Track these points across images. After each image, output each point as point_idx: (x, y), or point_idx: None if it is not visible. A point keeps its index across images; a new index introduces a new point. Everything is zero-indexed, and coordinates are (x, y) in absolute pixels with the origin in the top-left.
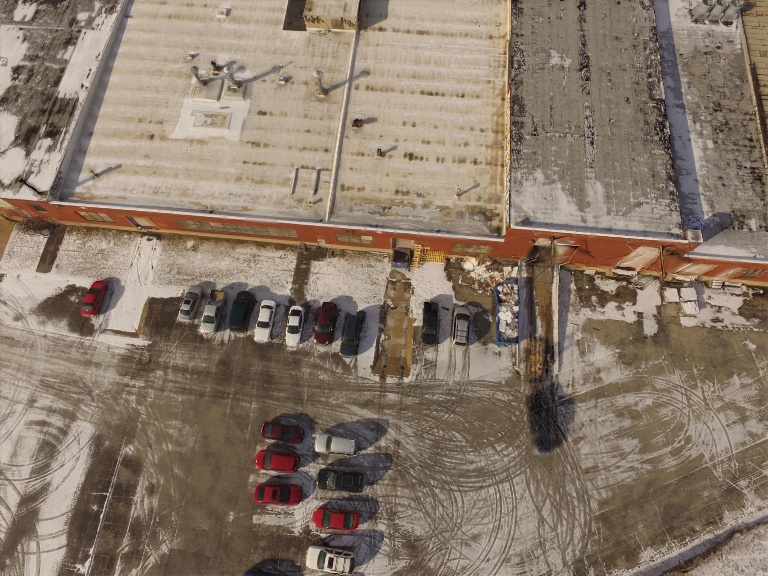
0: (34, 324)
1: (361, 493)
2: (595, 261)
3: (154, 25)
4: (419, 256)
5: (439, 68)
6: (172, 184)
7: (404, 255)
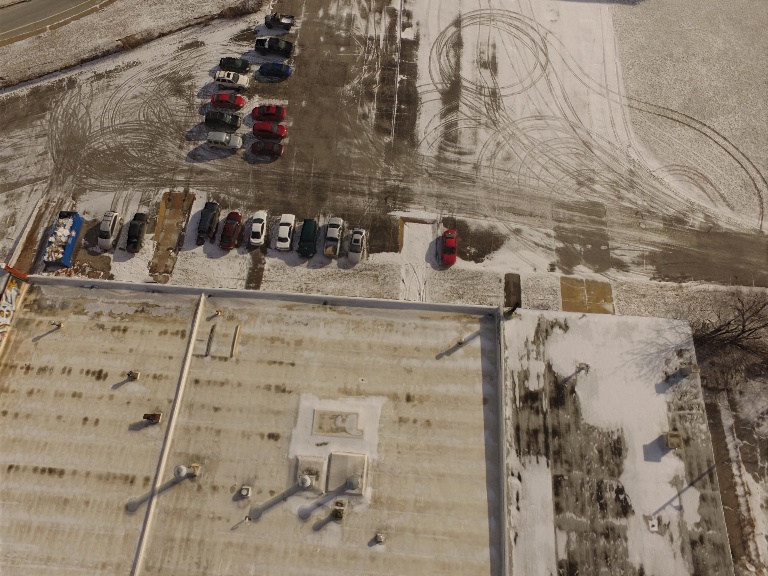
0: (500, 226)
1: None
2: None
3: None
4: None
5: (27, 519)
6: (373, 336)
7: None
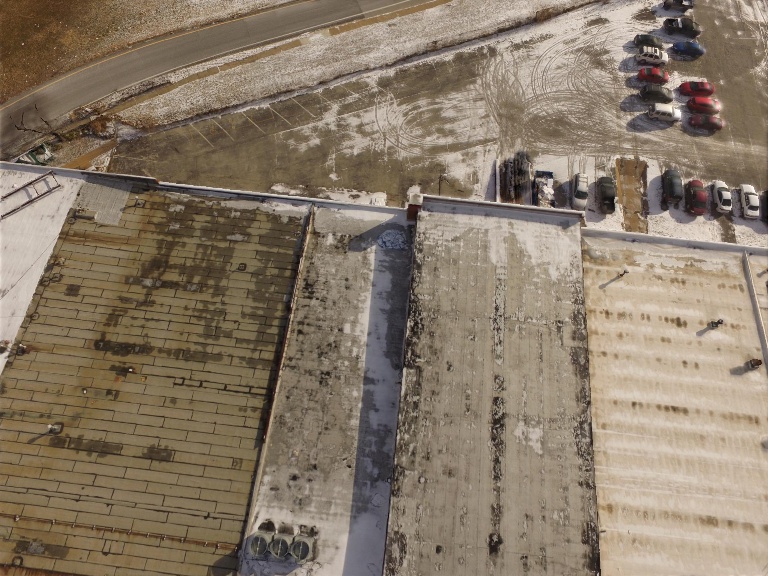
0: None
1: None
2: None
3: None
4: None
5: (673, 452)
6: None
7: None
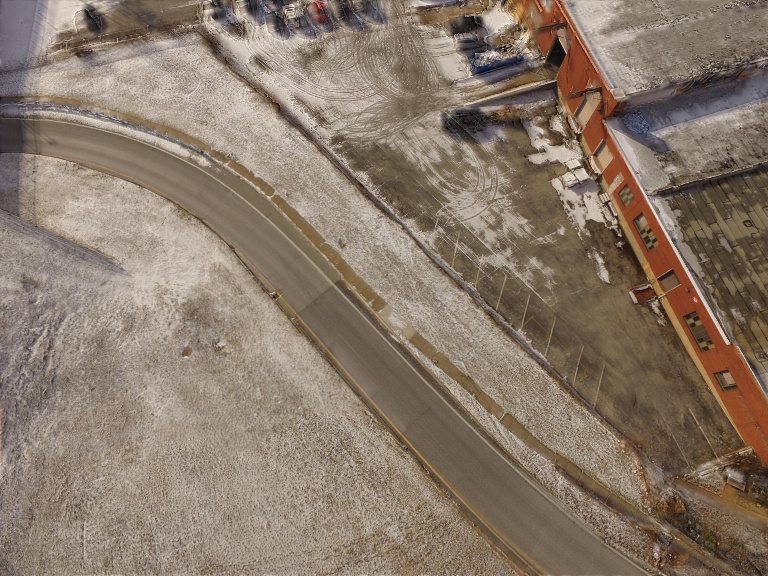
0: None
1: (333, 22)
2: (567, 93)
3: None
4: None
5: None
6: None
7: None
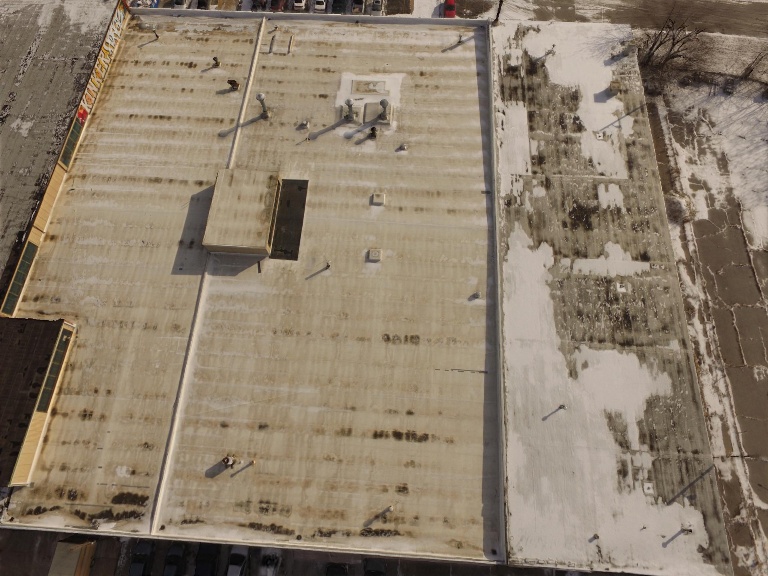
0: None
1: None
2: None
3: (453, 183)
4: None
5: (147, 142)
6: (394, 40)
7: None
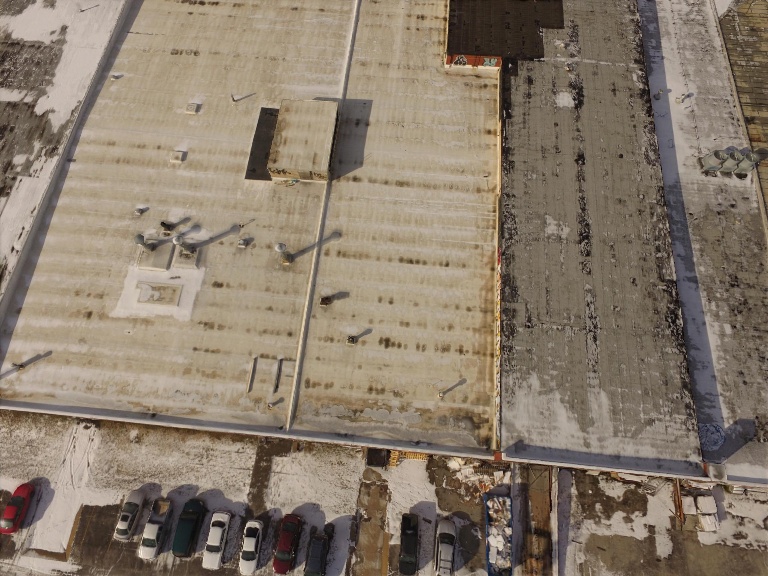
0: None
1: None
2: None
3: (100, 171)
4: (397, 458)
5: (420, 229)
6: (109, 377)
7: (380, 450)
